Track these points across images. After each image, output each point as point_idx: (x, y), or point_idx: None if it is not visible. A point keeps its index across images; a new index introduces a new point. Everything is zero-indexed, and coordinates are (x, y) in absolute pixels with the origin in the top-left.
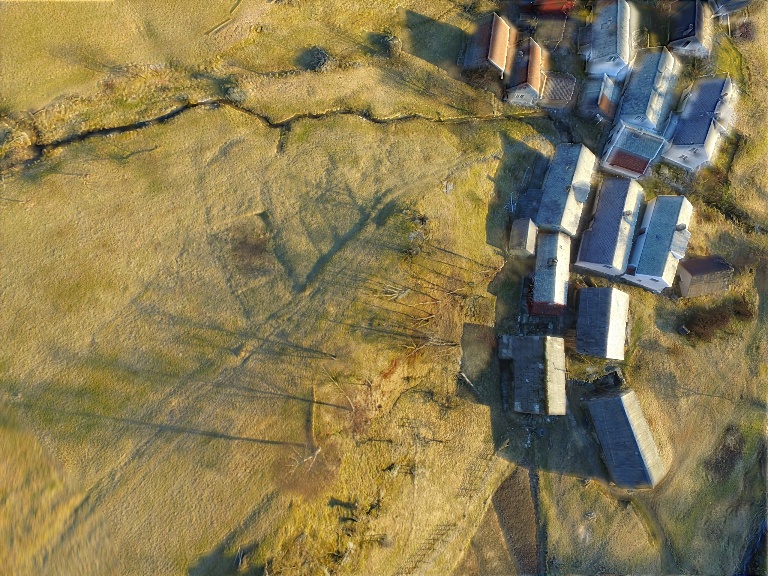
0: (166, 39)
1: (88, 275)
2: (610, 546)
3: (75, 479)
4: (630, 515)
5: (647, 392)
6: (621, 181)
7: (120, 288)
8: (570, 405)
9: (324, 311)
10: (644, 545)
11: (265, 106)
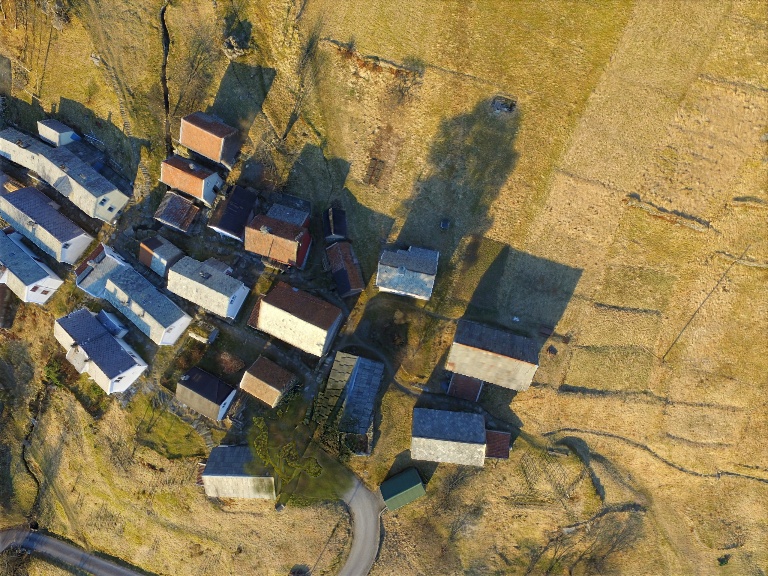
0: None
1: None
2: None
3: None
4: None
5: None
6: (67, 237)
7: None
8: None
9: None
10: None
11: None
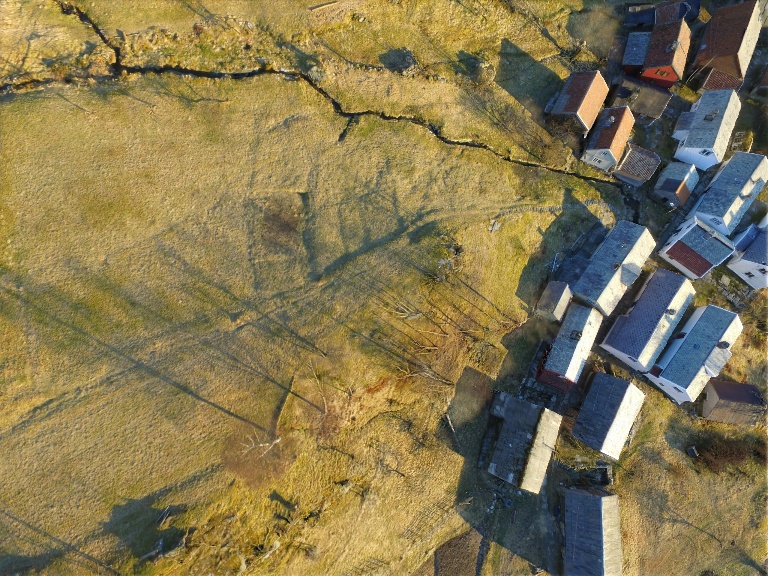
0: (271, 3)
1: (122, 198)
2: None
3: (41, 385)
4: None
5: (632, 501)
6: (675, 277)
7: (147, 220)
8: (547, 486)
9: (330, 307)
10: None
11: (342, 93)
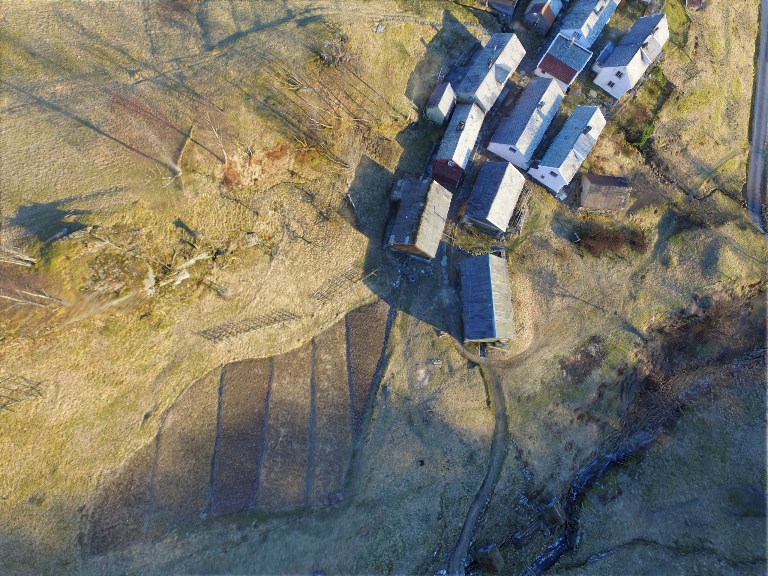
0: None
1: None
2: (447, 392)
3: None
4: (475, 374)
5: (525, 279)
6: (544, 80)
7: None
8: (448, 266)
9: (224, 71)
10: (481, 404)
11: None
